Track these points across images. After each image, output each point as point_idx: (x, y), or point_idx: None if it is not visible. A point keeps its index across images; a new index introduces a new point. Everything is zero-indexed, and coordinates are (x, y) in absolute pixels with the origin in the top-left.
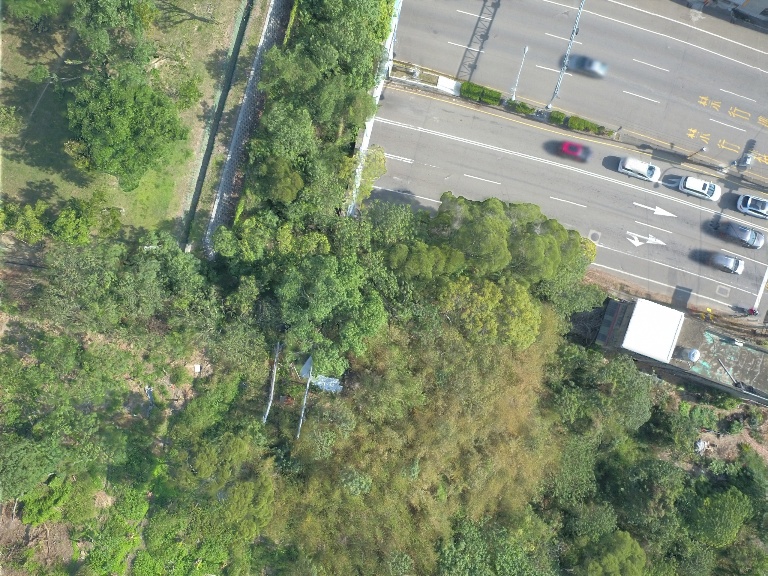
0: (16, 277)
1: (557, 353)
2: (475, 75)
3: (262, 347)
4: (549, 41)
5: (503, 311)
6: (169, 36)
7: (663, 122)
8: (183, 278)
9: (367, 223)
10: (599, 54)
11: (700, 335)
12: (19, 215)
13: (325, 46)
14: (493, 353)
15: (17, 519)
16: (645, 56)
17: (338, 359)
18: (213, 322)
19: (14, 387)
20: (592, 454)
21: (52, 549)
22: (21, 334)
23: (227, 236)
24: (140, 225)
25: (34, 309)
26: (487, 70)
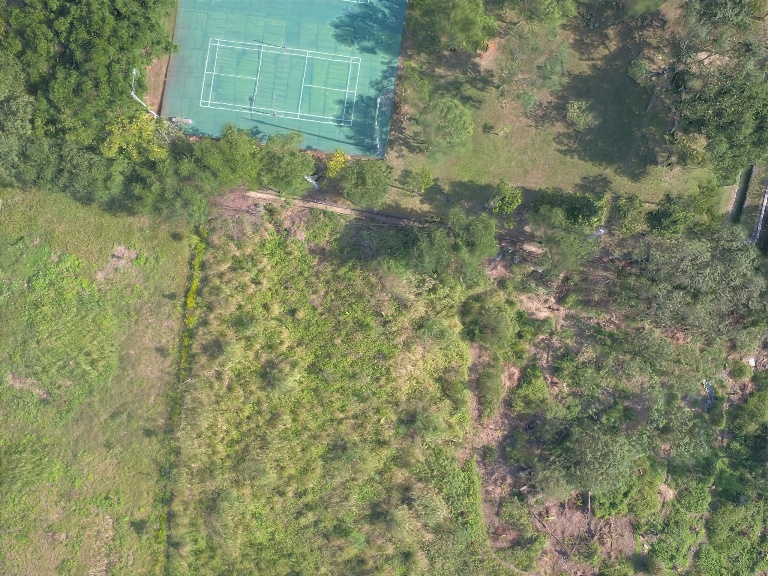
0: (586, 272)
1: None
2: None
3: None
4: None
5: None
6: (718, 32)
7: None
8: None
9: None
10: None
11: None
12: (625, 210)
13: None
14: None
15: (579, 513)
16: None
17: None
18: None
19: (575, 381)
20: None
21: (614, 543)
22: (578, 329)
23: None
24: None
25: None
26: None
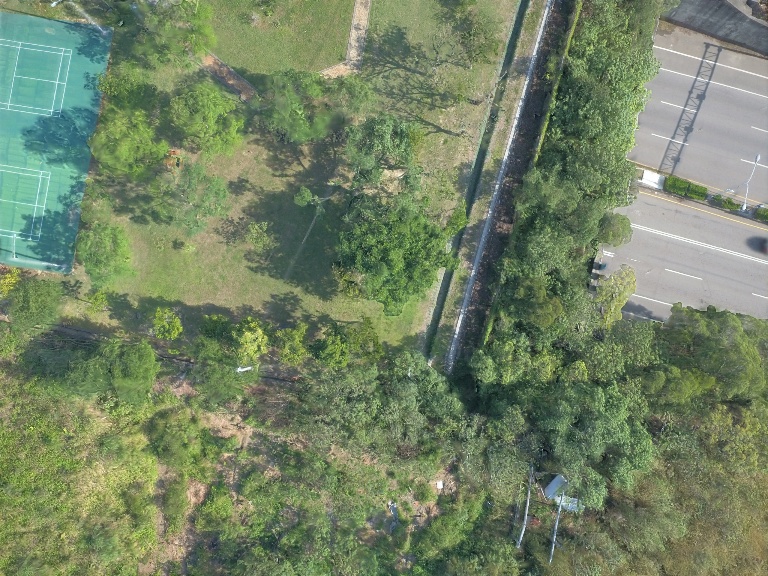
0: (266, 393)
1: None
2: (678, 168)
3: None
4: (755, 135)
5: (759, 440)
6: (415, 149)
7: None
8: (445, 404)
9: (619, 346)
10: None
11: None
12: (285, 340)
13: (588, 170)
14: (757, 487)
15: None
16: None
17: None
18: (478, 451)
19: (259, 500)
20: None
21: None
22: (265, 447)
23: (489, 363)
24: (384, 340)
25: (288, 428)
26: (691, 163)
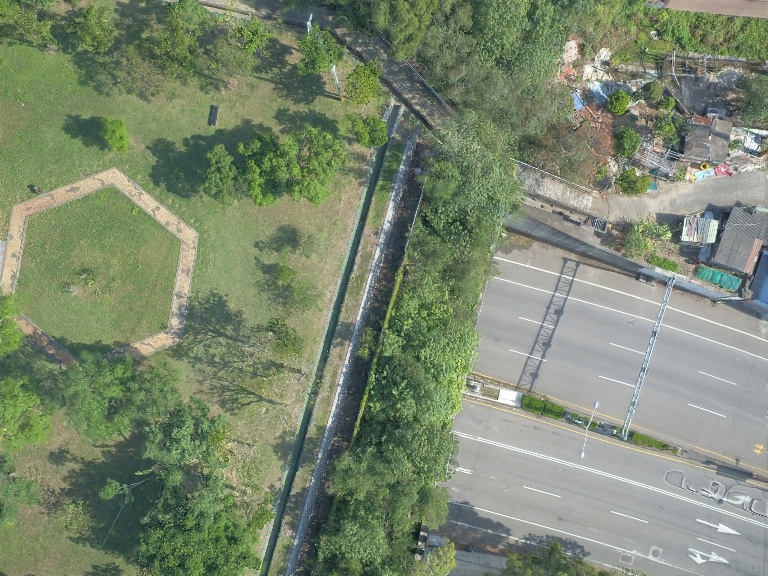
0: None
1: None
2: (536, 384)
3: None
4: (613, 351)
5: None
6: (237, 419)
7: (729, 437)
8: None
9: None
10: (664, 365)
11: None
12: None
13: (398, 457)
14: None
15: None
16: (712, 368)
17: None
18: None
19: None
20: None
21: None
22: None
23: None
24: None
25: None
26: (549, 379)
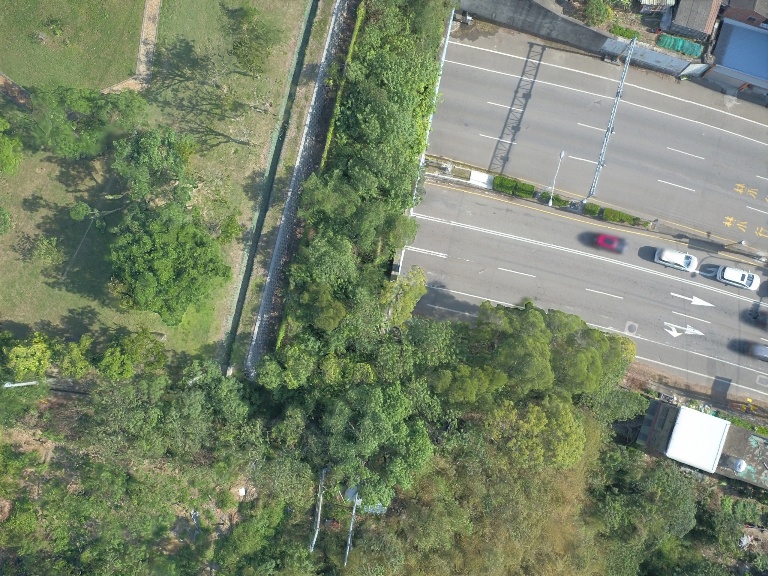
0: (61, 407)
1: (599, 459)
2: (507, 167)
3: (308, 478)
4: (581, 131)
5: (548, 435)
6: (206, 160)
7: (699, 210)
8: (228, 411)
9: (409, 346)
10: (633, 143)
11: (745, 442)
12: (65, 354)
13: (364, 173)
14: (540, 482)
15: None
16: (679, 144)
17: (385, 491)
18: (259, 457)
19: (62, 514)
20: (636, 560)
21: None
22: (67, 461)
23: (271, 368)
24: (182, 350)
25: (81, 441)
26: (519, 162)
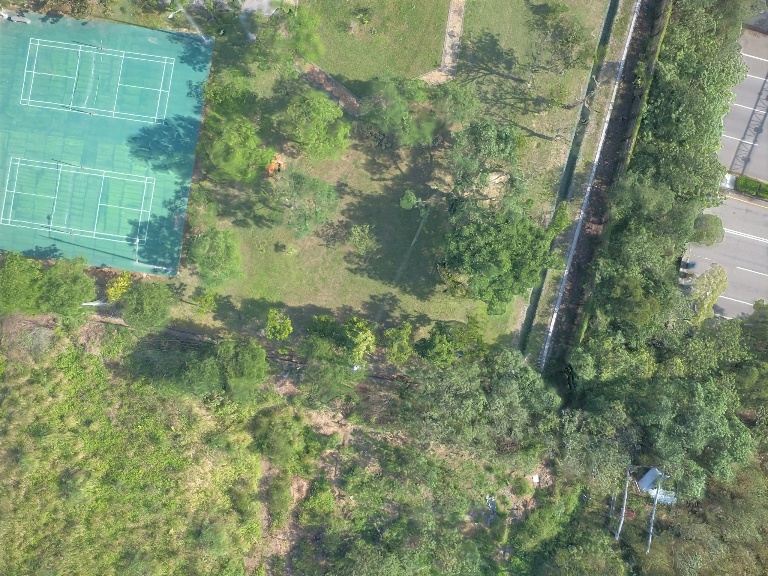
0: (368, 391)
1: None
2: (748, 168)
3: None
4: None
5: None
6: None
7: None
8: (547, 400)
9: (711, 342)
10: None
11: None
12: (393, 339)
13: (683, 172)
14: None
15: None
16: None
17: None
18: (581, 446)
19: (361, 495)
20: None
21: None
22: (365, 443)
23: (590, 360)
24: None
25: (392, 425)
26: (761, 163)
